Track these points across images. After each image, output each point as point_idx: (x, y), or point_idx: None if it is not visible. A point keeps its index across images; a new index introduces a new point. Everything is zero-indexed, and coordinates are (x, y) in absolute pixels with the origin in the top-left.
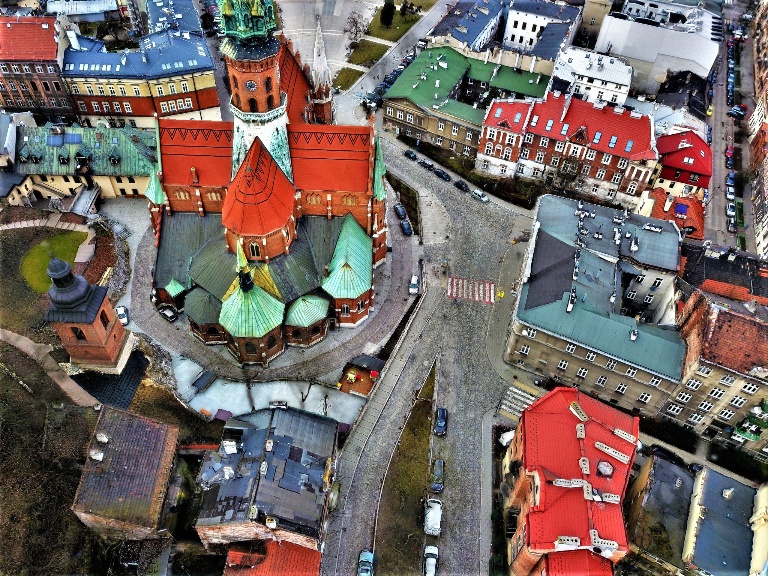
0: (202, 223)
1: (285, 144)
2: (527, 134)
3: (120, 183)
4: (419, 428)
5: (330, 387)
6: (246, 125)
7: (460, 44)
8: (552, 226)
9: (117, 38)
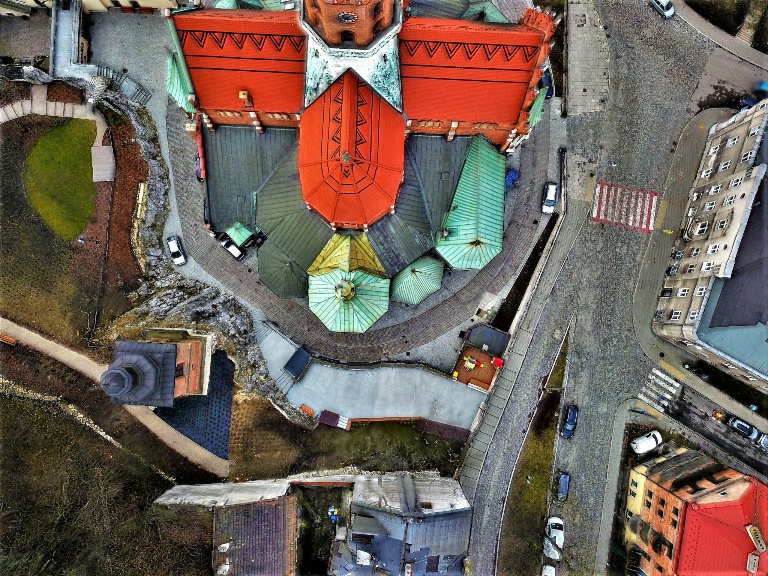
0: (262, 143)
1: (395, 69)
2: None
3: None
4: (545, 431)
5: (445, 377)
6: None
7: None
8: None
9: None
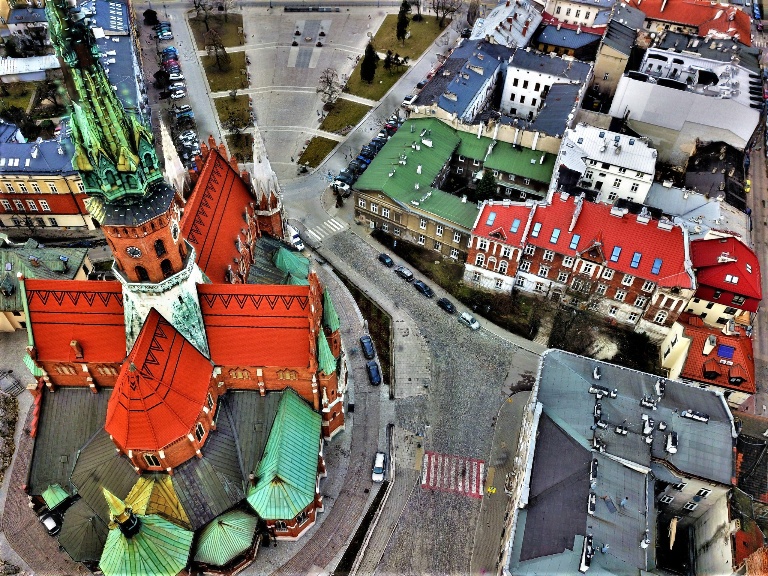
0: (95, 402)
1: (194, 313)
2: (527, 245)
3: (18, 316)
4: None
5: None
6: (135, 295)
7: (448, 115)
8: (559, 407)
9: (56, 103)
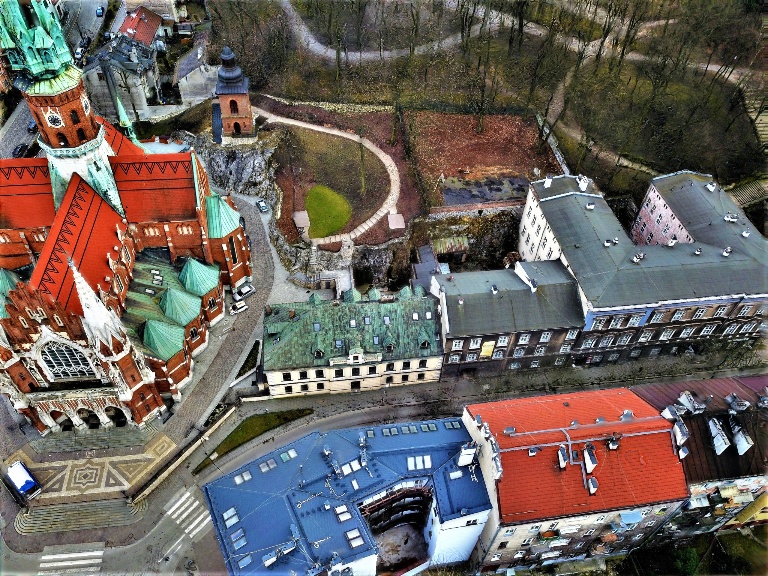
0: None
1: None
2: None
3: None
4: None
5: None
6: None
7: None
8: None
9: None
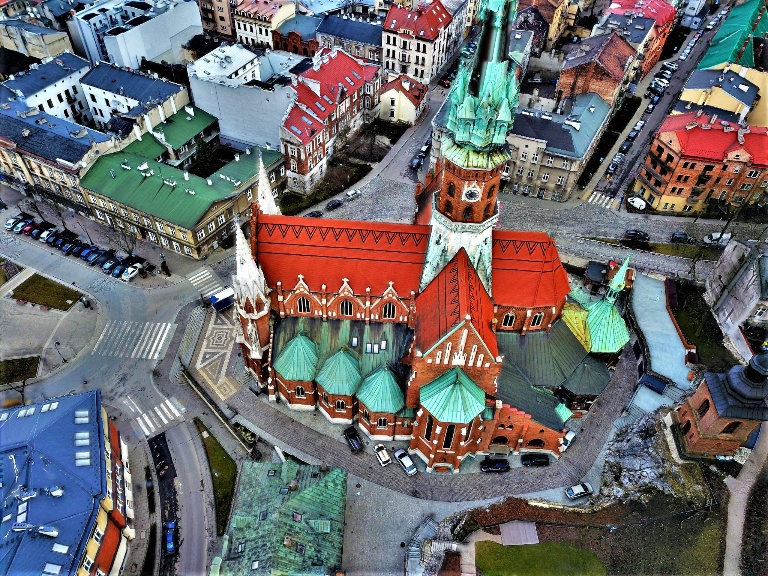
0: None
1: None
2: None
3: None
4: (649, 245)
5: (633, 292)
6: None
7: (108, 144)
8: None
9: None
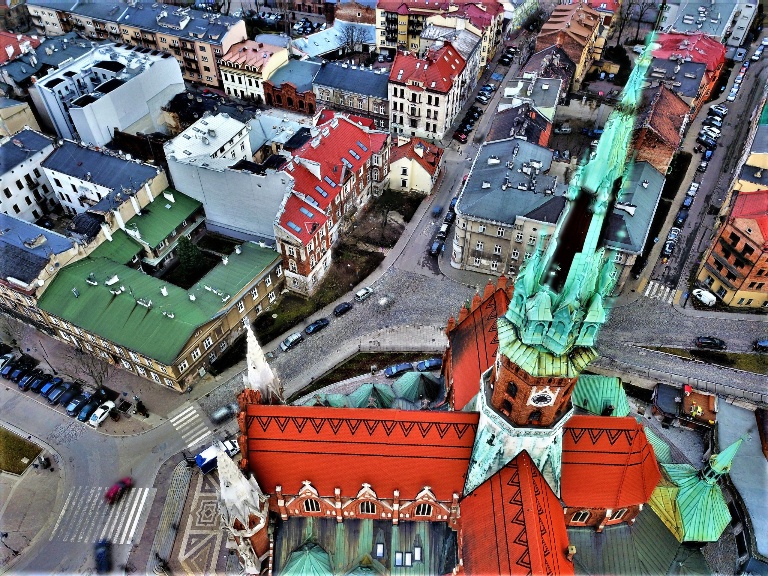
0: None
1: None
2: None
3: None
4: None
5: (718, 430)
6: None
7: (70, 252)
8: (515, 210)
9: None
